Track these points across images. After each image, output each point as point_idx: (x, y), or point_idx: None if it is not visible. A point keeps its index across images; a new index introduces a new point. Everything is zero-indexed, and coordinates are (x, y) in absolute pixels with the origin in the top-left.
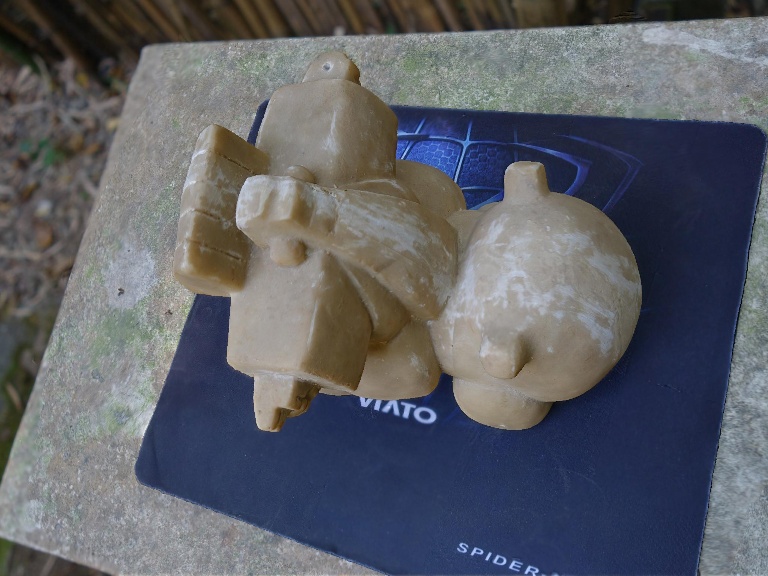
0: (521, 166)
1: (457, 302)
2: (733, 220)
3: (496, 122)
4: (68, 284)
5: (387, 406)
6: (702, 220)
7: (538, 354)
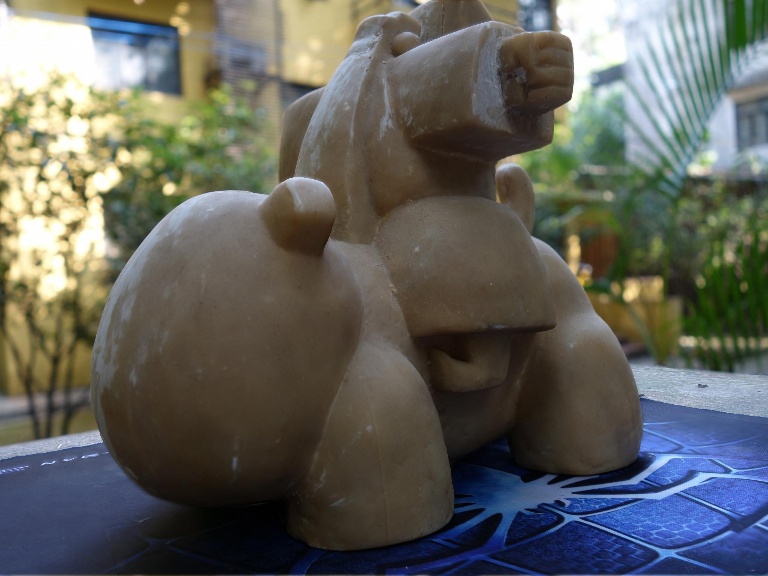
0: None
1: None
2: None
3: None
4: (745, 374)
5: None
6: None
7: None
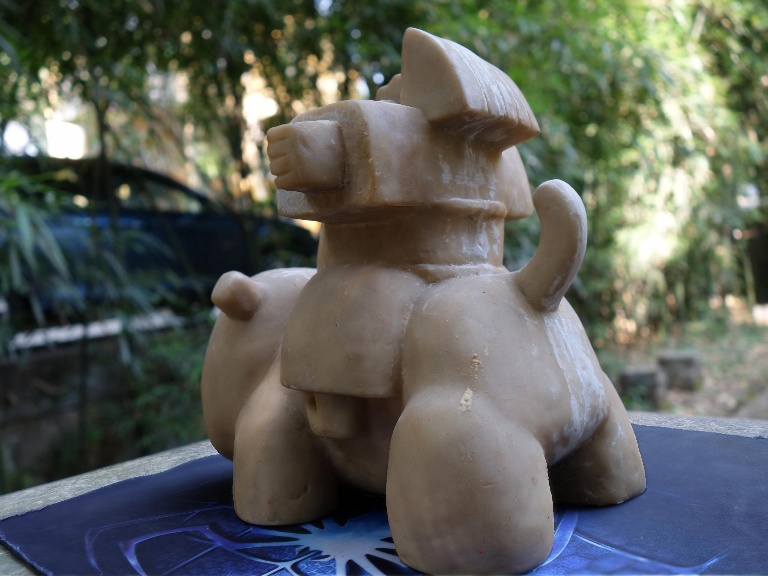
0: (229, 273)
1: None
2: None
3: None
4: None
5: None
6: (125, 496)
7: None
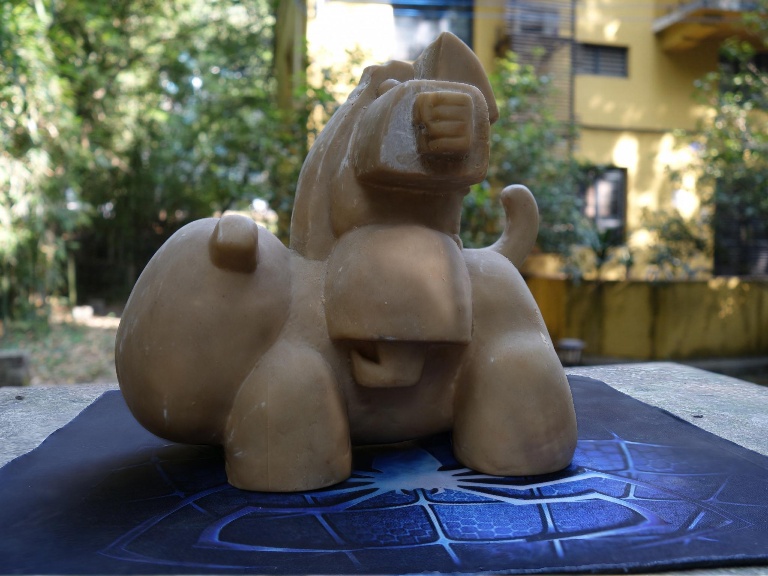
0: (237, 216)
1: None
2: None
3: (405, 567)
4: None
5: None
6: (14, 521)
7: None
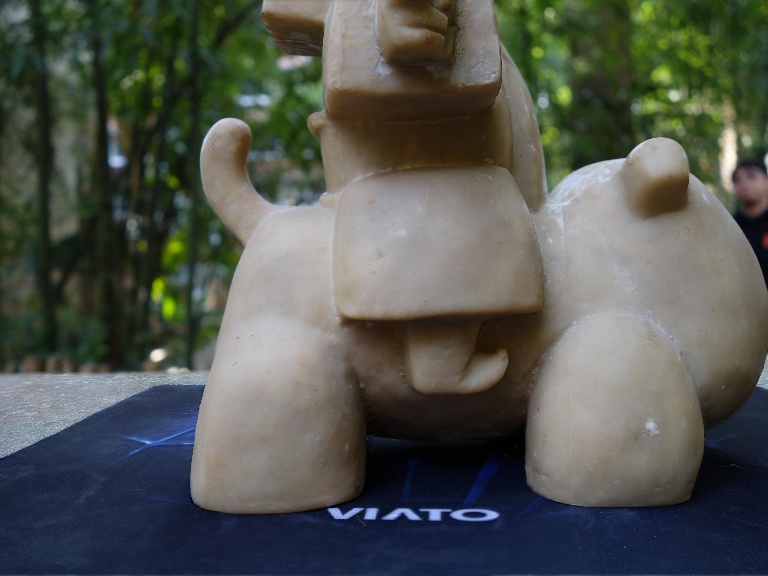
0: None
1: (559, 199)
2: (764, 399)
3: None
4: None
5: (391, 514)
6: None
7: (694, 198)
